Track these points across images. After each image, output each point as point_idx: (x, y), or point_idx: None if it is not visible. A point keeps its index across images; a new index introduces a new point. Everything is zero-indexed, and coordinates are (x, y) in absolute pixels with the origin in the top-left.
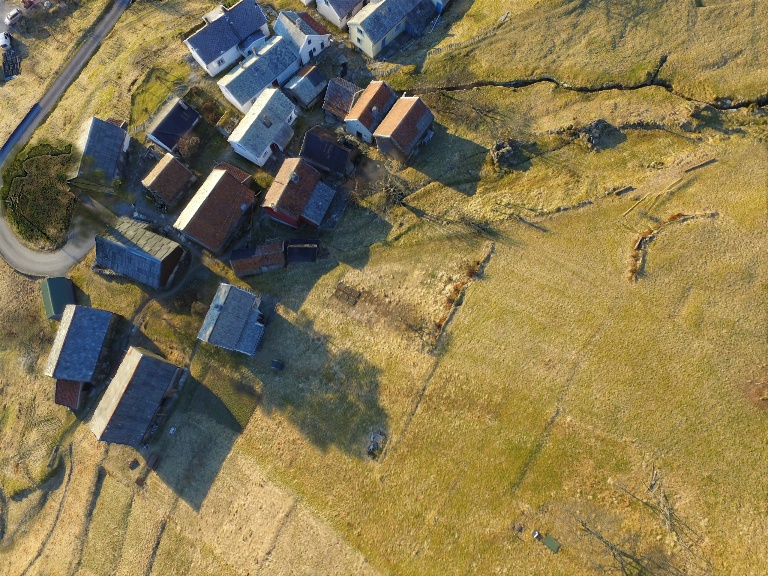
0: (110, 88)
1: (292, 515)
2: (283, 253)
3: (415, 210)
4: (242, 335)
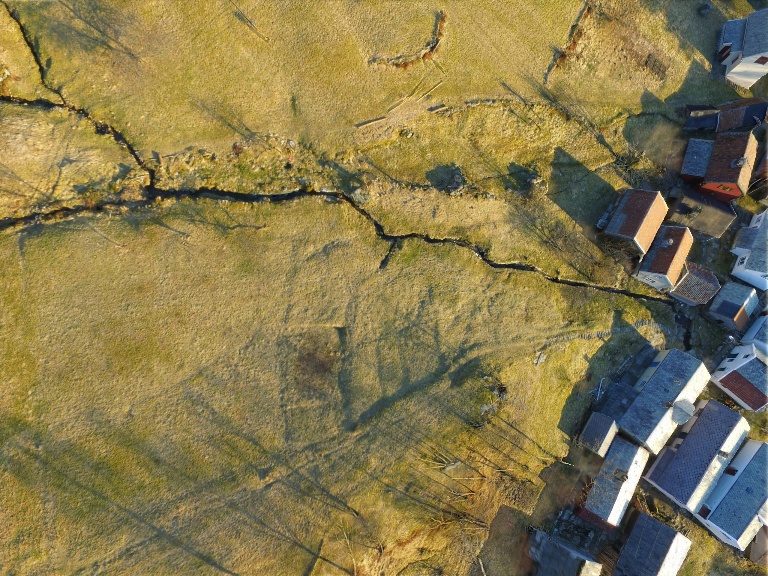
0: None
1: None
2: None
3: (605, 144)
4: (743, 31)
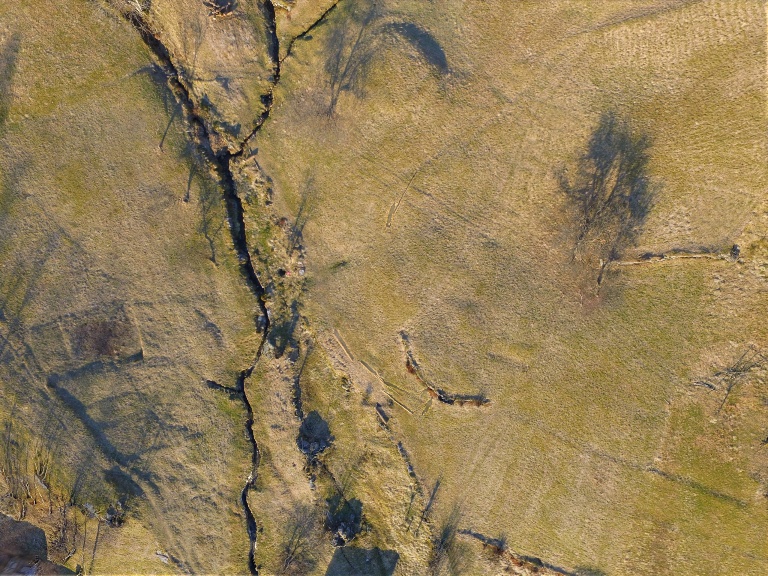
0: None
1: None
2: None
3: None
4: None
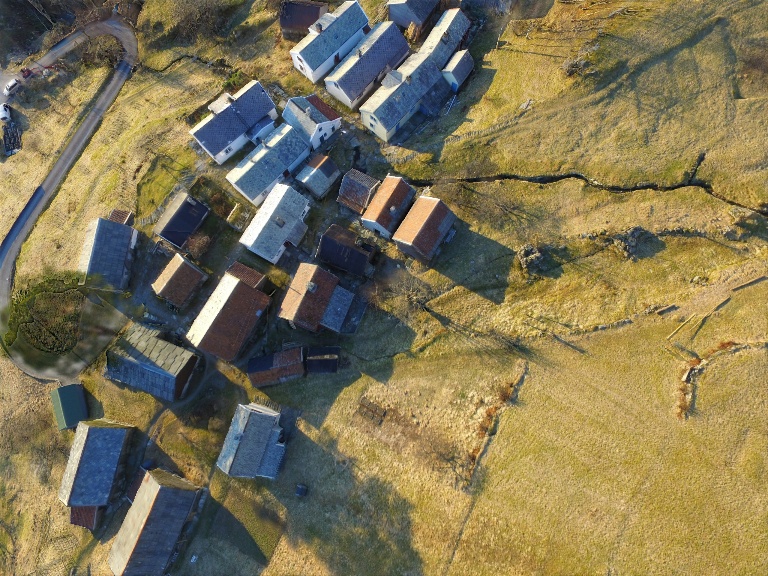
0: (114, 174)
1: None
2: (302, 363)
3: (440, 317)
4: (263, 459)
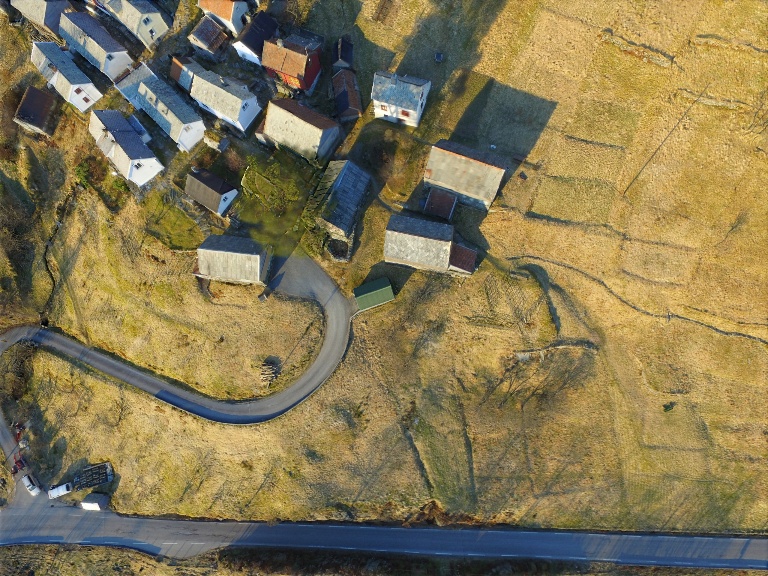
0: (155, 291)
1: (553, 8)
2: (344, 70)
3: None
4: None
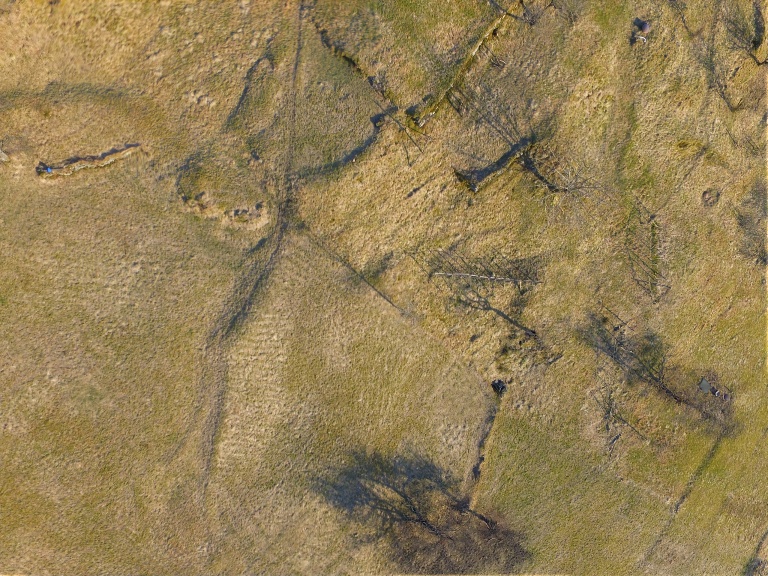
0: None
1: None
2: None
3: None
4: None
